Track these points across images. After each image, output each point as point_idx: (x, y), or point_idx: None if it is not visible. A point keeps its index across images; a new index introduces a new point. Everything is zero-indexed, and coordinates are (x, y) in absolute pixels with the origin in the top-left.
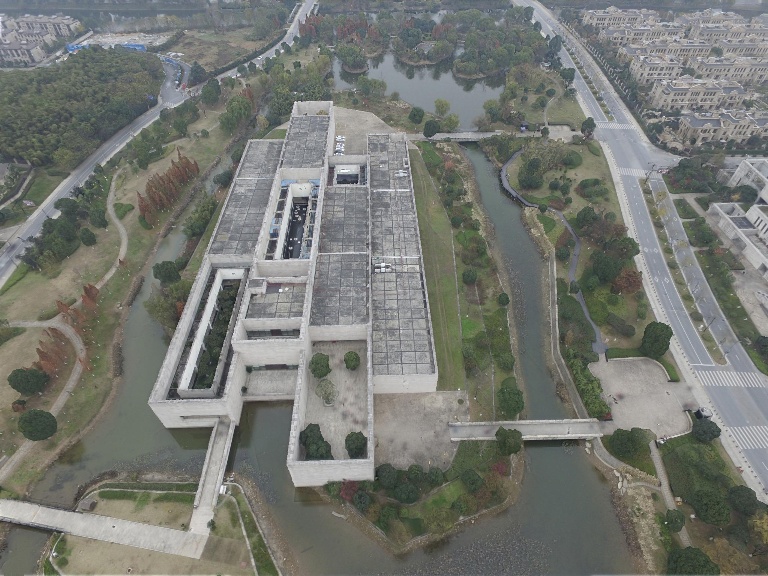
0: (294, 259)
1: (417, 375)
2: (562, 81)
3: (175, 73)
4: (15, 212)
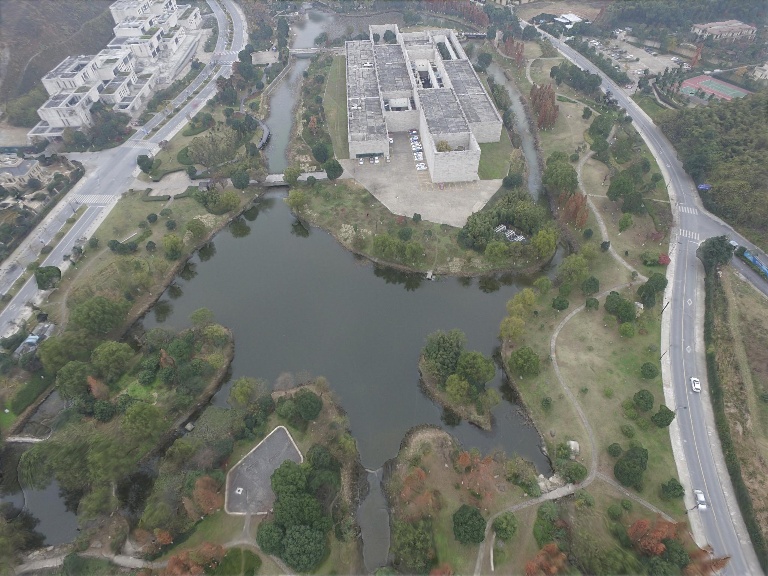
0: (415, 51)
1: (354, 41)
2: (52, 299)
3: (760, 253)
4: (643, 95)
